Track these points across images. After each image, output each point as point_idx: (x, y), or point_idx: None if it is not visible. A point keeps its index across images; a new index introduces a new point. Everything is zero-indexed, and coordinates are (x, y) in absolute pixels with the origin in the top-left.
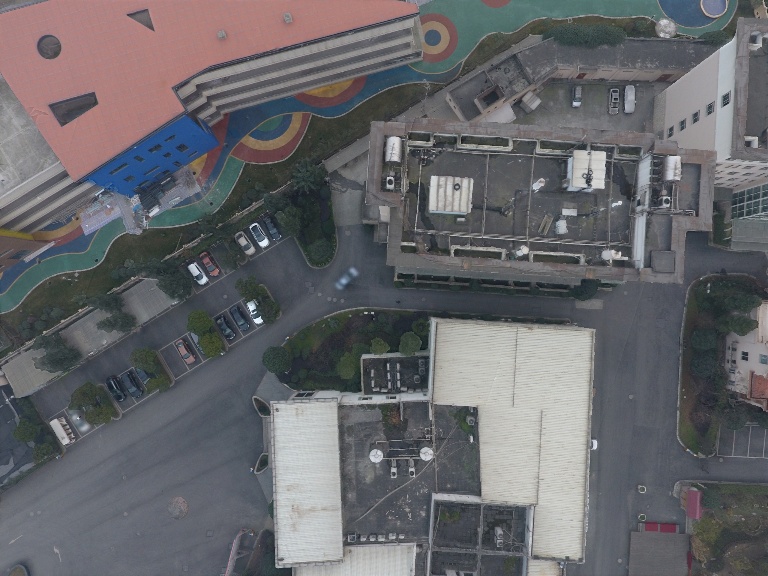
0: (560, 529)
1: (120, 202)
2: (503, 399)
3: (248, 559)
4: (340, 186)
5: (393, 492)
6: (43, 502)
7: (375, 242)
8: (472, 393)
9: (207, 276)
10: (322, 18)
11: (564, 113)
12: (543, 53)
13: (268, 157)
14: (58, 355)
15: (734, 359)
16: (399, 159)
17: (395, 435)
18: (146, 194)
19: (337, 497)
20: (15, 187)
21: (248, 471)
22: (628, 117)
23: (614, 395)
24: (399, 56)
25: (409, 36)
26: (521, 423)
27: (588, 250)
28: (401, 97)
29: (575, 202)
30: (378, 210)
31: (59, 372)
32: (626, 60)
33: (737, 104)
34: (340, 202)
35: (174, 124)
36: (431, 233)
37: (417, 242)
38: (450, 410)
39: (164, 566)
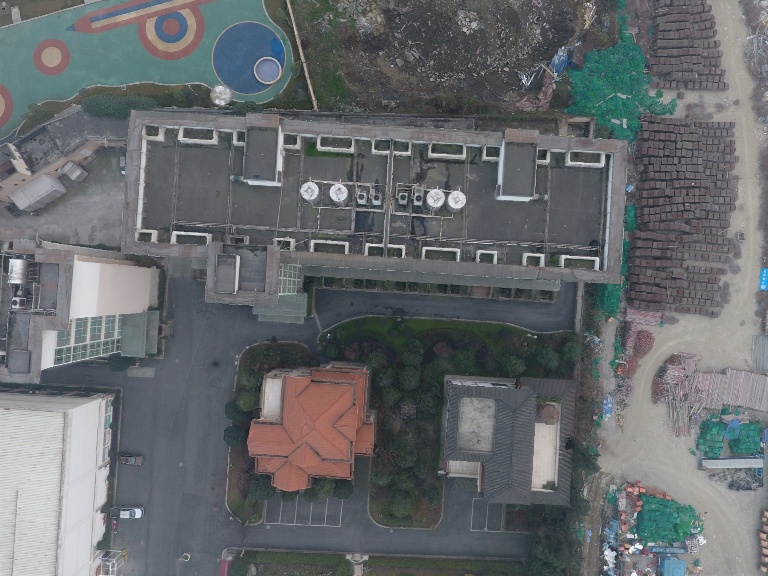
0: None
1: None
2: None
3: None
4: None
5: None
6: None
7: None
8: None
9: None
10: None
11: (117, 181)
12: (73, 125)
13: None
14: None
15: None
16: None
17: None
18: None
19: None
20: None
21: None
22: None
23: (164, 463)
24: None
25: None
26: None
27: None
28: None
29: None
30: None
31: None
32: None
33: (127, 198)
34: None
35: None
36: None
37: None
38: None
39: None
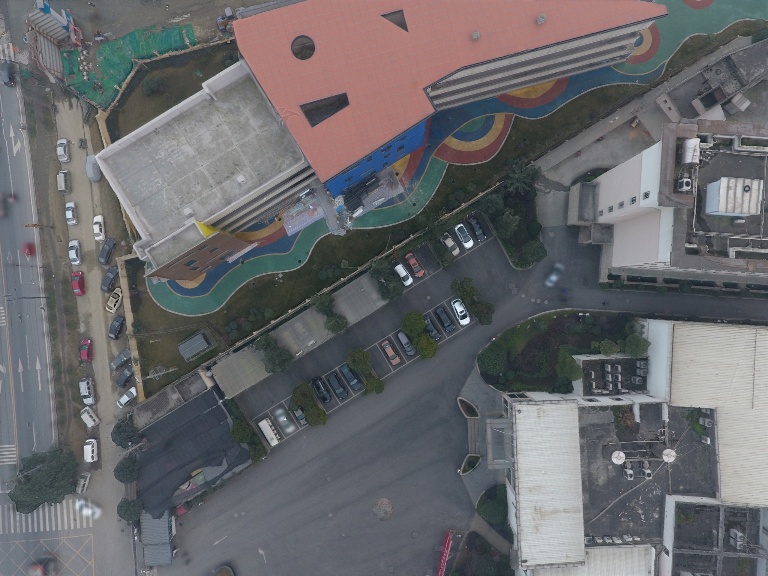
0: None
1: (323, 203)
2: (742, 401)
3: (454, 560)
4: (543, 187)
5: (626, 494)
6: (247, 503)
7: (580, 243)
8: (710, 395)
9: (412, 277)
10: (573, 19)
11: (767, 114)
12: (757, 54)
13: (471, 158)
14: (283, 356)
15: None
16: (698, 161)
17: (627, 437)
18: (351, 195)
19: (579, 499)
20: (257, 188)
21: (453, 472)
22: None
23: None
24: (611, 57)
25: (636, 37)
26: (761, 425)
27: None
28: (605, 98)
29: None
30: (593, 211)
31: (270, 373)
32: None
33: None
34: (543, 203)
35: None
36: (709, 235)
37: (697, 244)
38: (682, 412)
39: (369, 567)
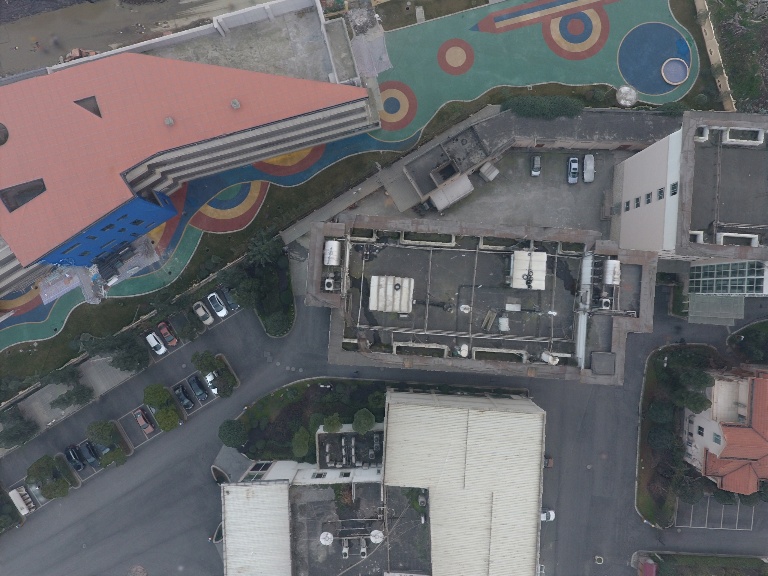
0: None
1: (79, 271)
2: (454, 481)
3: None
4: (298, 255)
5: (345, 571)
6: (4, 570)
7: None
8: (423, 475)
9: (165, 346)
10: (270, 103)
11: (523, 182)
12: (500, 125)
13: (226, 226)
14: (13, 432)
15: (691, 432)
16: (337, 262)
17: (347, 514)
18: (104, 264)
19: None
20: None
21: (207, 540)
22: (588, 186)
23: (572, 465)
24: (356, 127)
25: (363, 113)
26: (472, 505)
27: (532, 345)
28: (360, 166)
29: (519, 297)
30: None
31: None
32: (584, 132)
33: (682, 199)
34: (298, 271)
35: (124, 206)
36: (374, 329)
37: (359, 339)
38: (402, 489)
39: None
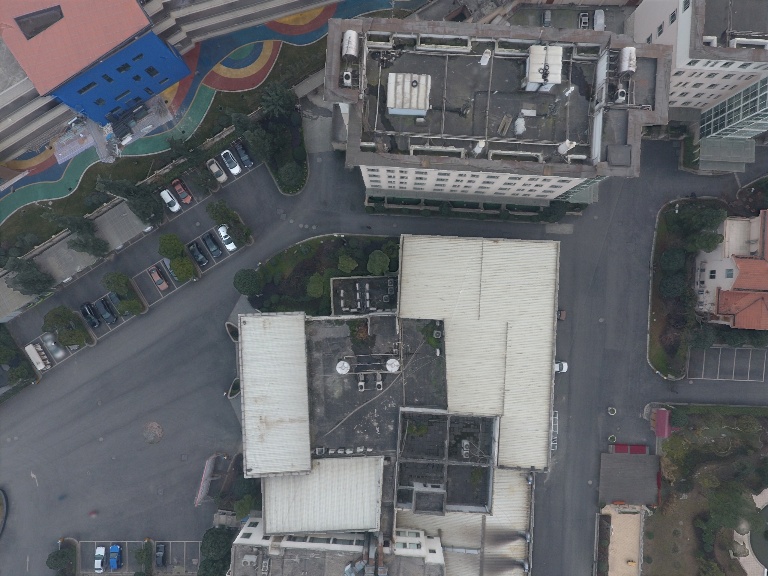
0: (525, 439)
1: (93, 131)
2: (469, 312)
3: (222, 483)
4: (311, 113)
5: (361, 407)
6: (20, 428)
7: (346, 168)
8: (438, 306)
9: (180, 203)
10: None
11: None
12: None
13: (239, 85)
14: (30, 275)
15: (703, 280)
16: (355, 53)
17: (363, 350)
18: (118, 122)
19: (305, 409)
20: None
21: (222, 396)
22: None
23: (584, 319)
24: None
25: None
26: (487, 335)
27: (547, 150)
28: None
29: (534, 103)
30: None
31: (33, 297)
32: None
33: (695, 3)
34: (311, 129)
35: (140, 40)
36: (391, 134)
37: (377, 142)
38: (417, 325)
39: (139, 490)
